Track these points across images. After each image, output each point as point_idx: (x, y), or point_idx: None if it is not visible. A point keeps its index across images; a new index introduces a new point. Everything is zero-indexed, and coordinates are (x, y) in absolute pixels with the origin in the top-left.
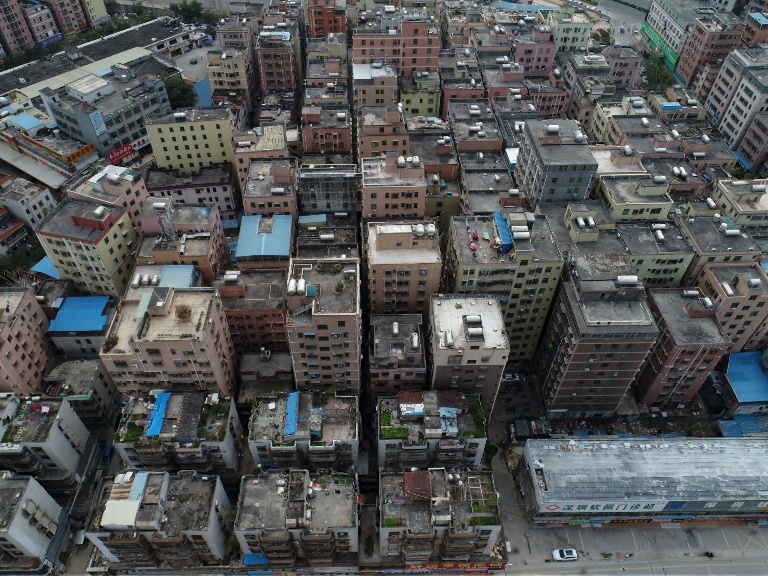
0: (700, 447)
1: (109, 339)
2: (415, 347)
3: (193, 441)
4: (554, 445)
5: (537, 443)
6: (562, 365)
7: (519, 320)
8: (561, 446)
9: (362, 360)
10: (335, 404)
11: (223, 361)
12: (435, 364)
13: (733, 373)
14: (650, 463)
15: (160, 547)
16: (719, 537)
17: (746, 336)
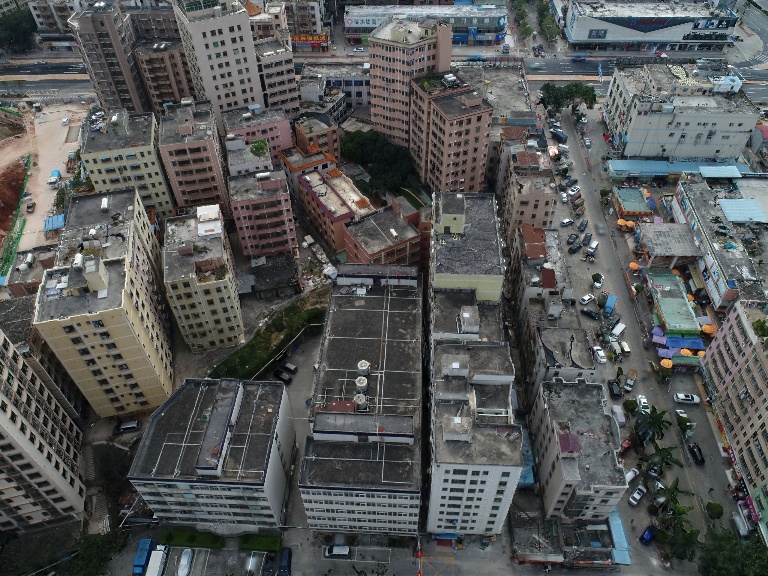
0: (421, 7)
1: None
2: None
3: None
4: (357, 7)
5: None
6: None
7: None
8: (360, 7)
9: None
10: None
11: None
12: None
13: None
14: (396, 10)
15: None
16: None
17: None
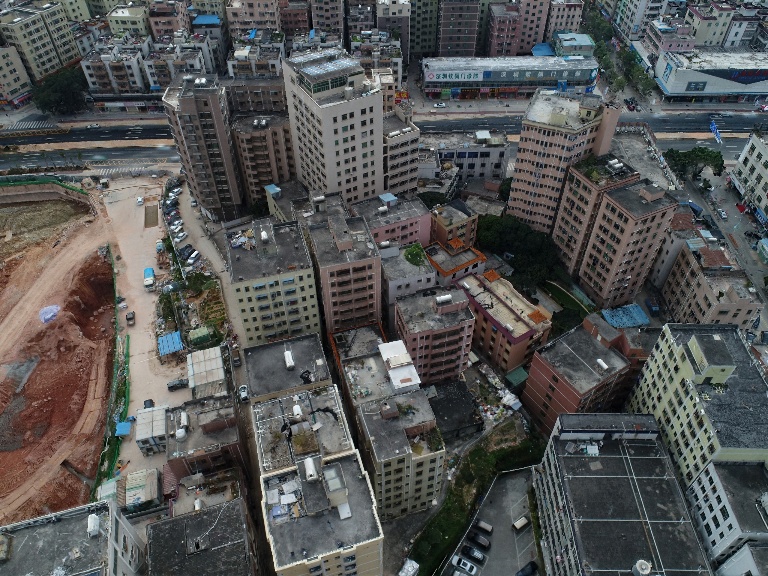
0: (504, 59)
1: (229, 4)
2: (368, 11)
3: (269, 42)
4: (435, 59)
5: (427, 59)
6: (440, 27)
7: (424, 18)
8: (438, 59)
9: (345, 29)
10: (332, 36)
11: (279, 25)
12: (377, 16)
13: (535, 49)
14: (479, 63)
15: (258, 69)
16: (515, 102)
17: (542, 30)
